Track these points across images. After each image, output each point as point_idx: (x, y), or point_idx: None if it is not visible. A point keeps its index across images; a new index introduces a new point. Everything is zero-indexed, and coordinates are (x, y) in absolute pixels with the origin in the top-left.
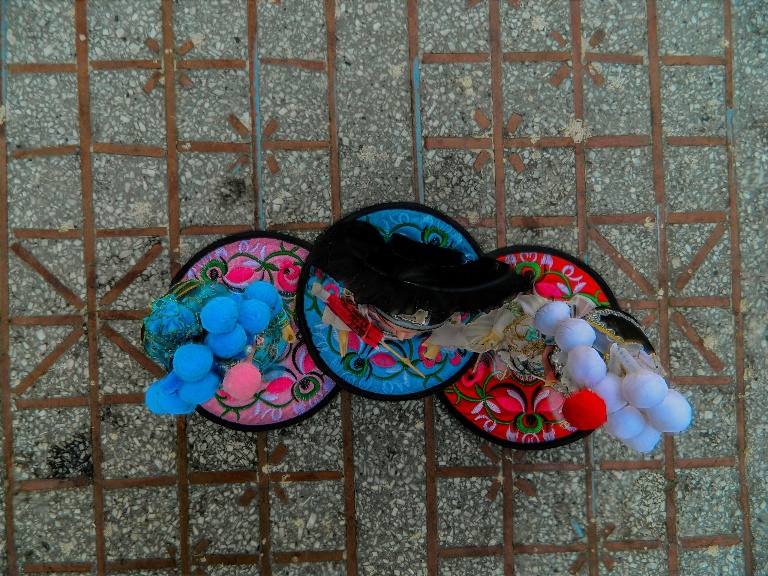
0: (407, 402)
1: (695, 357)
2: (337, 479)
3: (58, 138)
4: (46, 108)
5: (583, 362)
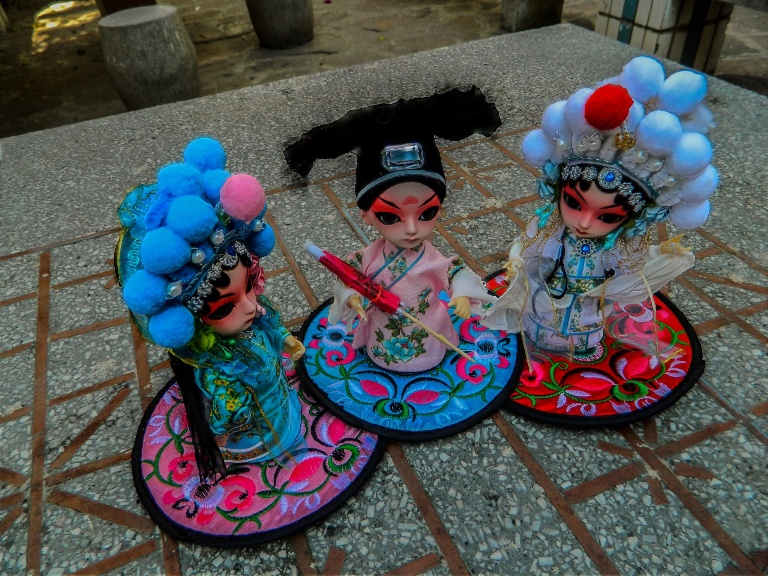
0: (476, 433)
1: (736, 292)
2: (435, 565)
3: (12, 343)
4: (2, 327)
5: (575, 95)
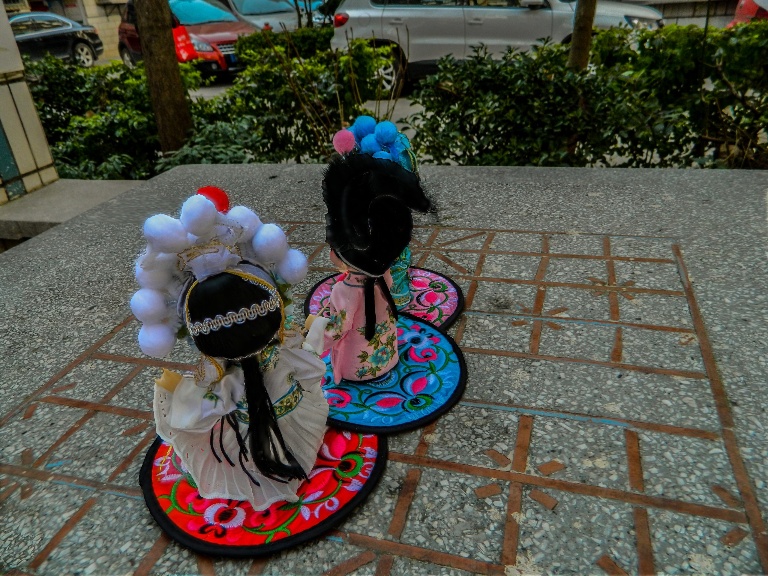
0: None
1: None
2: None
3: (555, 247)
4: None
5: None
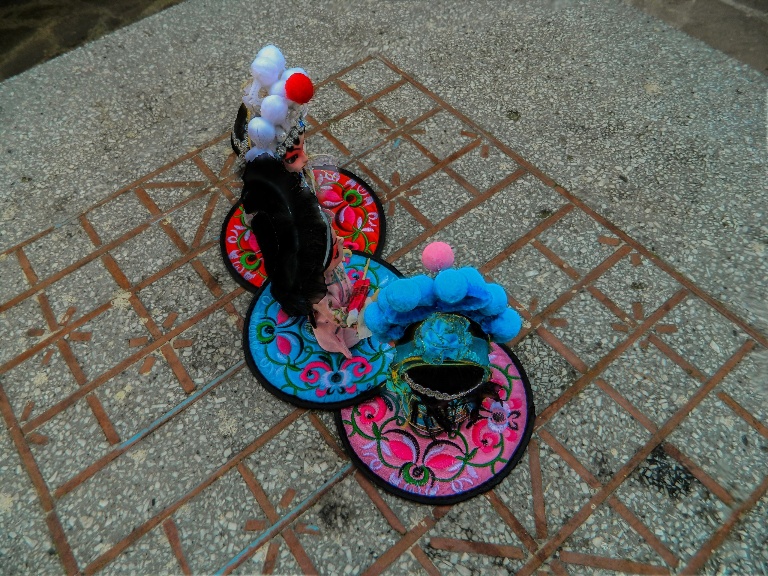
0: None
1: None
2: (490, 278)
3: None
4: None
5: (272, 106)
